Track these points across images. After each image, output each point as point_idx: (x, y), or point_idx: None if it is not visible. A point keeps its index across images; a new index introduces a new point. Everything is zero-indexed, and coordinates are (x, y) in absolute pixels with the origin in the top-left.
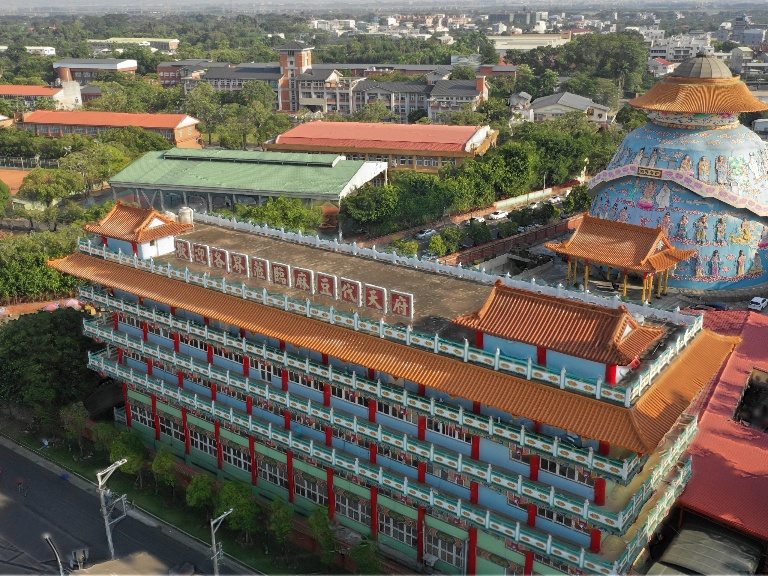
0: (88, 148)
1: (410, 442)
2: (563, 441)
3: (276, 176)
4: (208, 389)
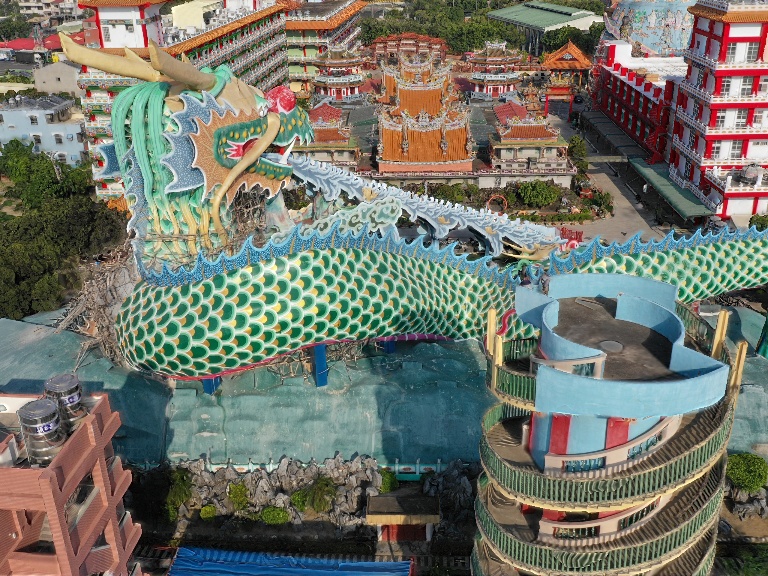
0: (527, 1)
1: None
2: None
3: (542, 17)
4: None
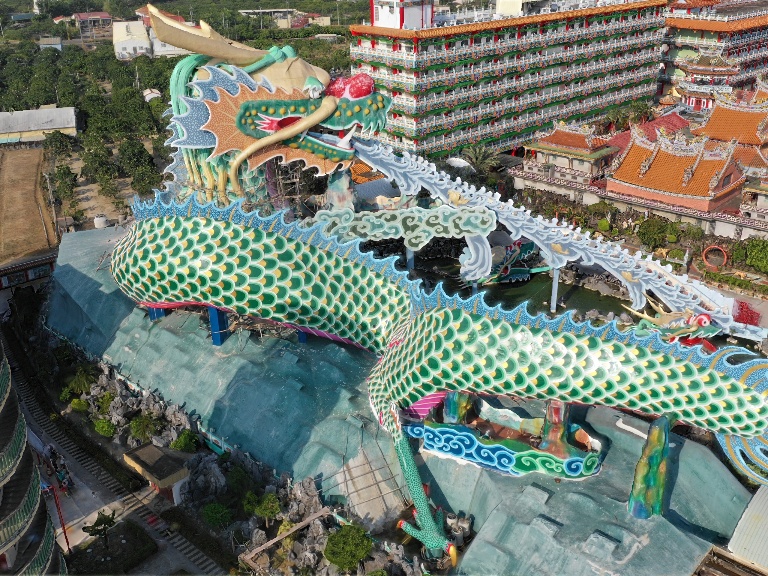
0: None
1: None
2: None
3: None
4: None
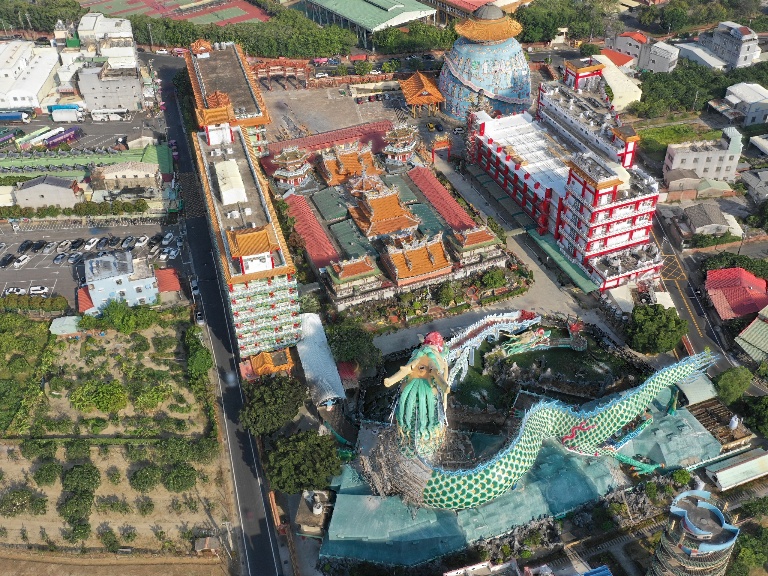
0: None
1: None
2: None
3: (362, 11)
4: None
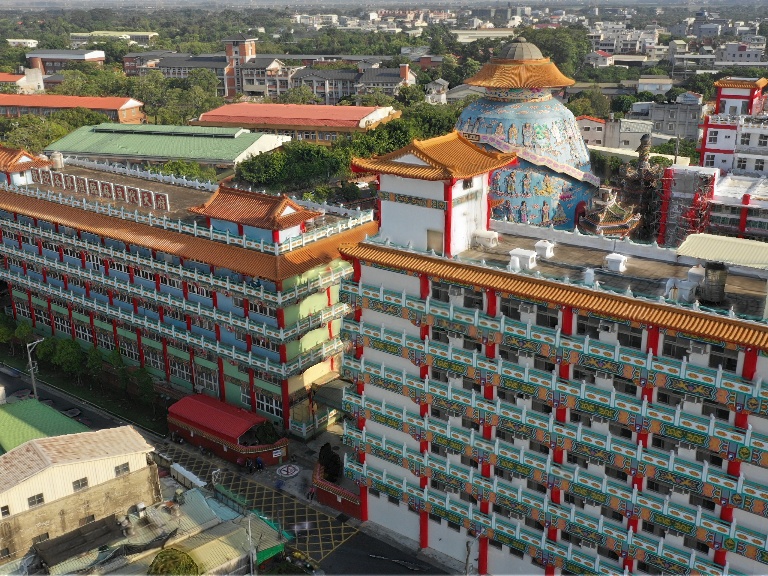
0: (34, 125)
1: (172, 298)
2: (252, 285)
3: (185, 145)
4: (62, 282)
